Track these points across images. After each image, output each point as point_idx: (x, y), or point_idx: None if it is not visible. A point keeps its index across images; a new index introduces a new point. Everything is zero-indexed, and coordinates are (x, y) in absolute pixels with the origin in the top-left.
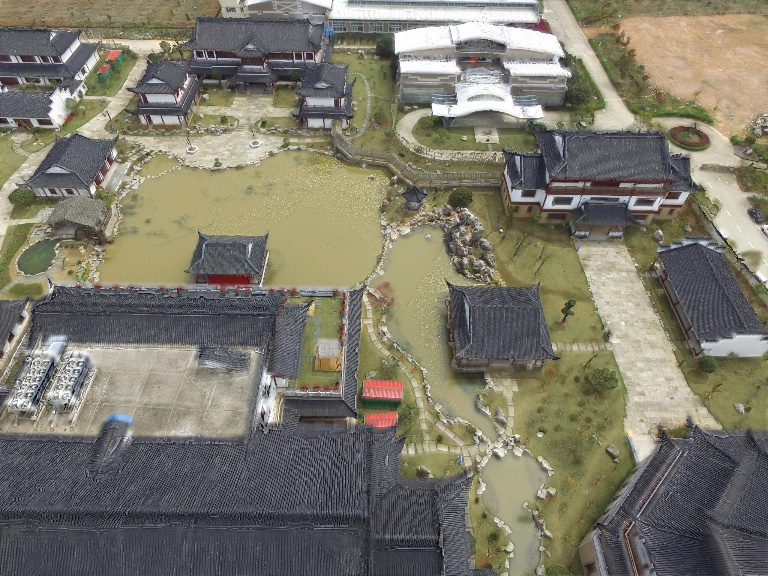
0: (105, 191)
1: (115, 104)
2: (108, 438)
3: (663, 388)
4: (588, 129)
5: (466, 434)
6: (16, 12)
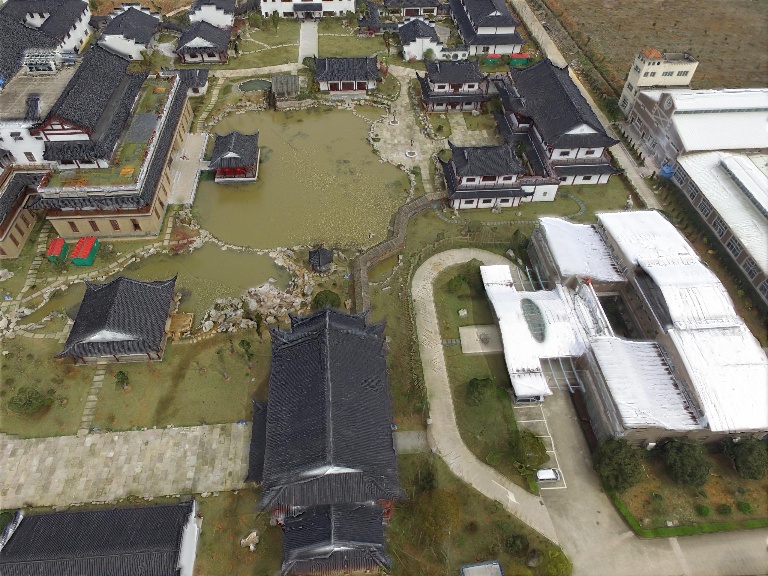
0: None
1: None
2: None
3: (10, 478)
4: None
5: (30, 304)
6: (575, 5)
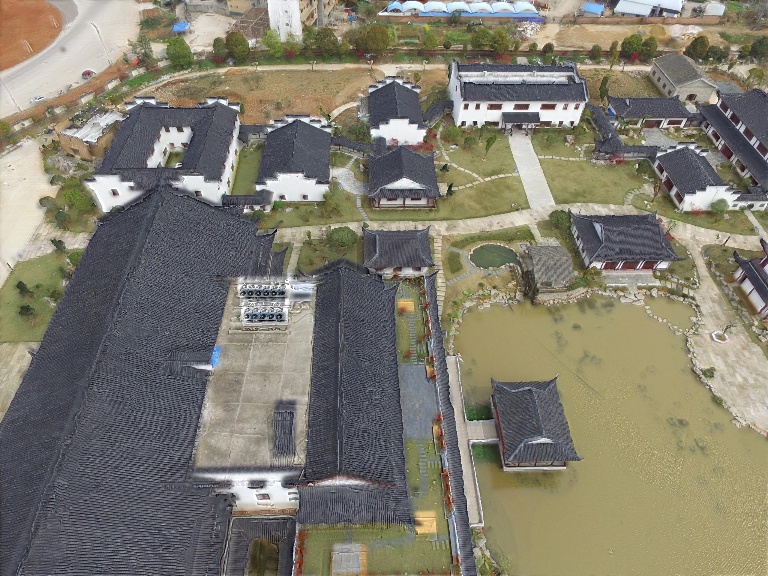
0: (600, 276)
1: (755, 240)
2: (199, 359)
3: None
4: None
5: None
6: None
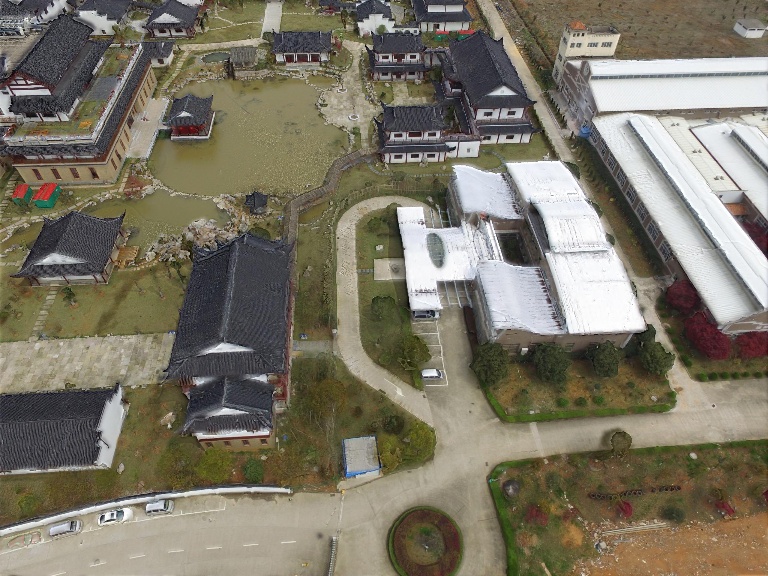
0: None
1: None
2: None
3: None
4: (421, 380)
5: None
6: None
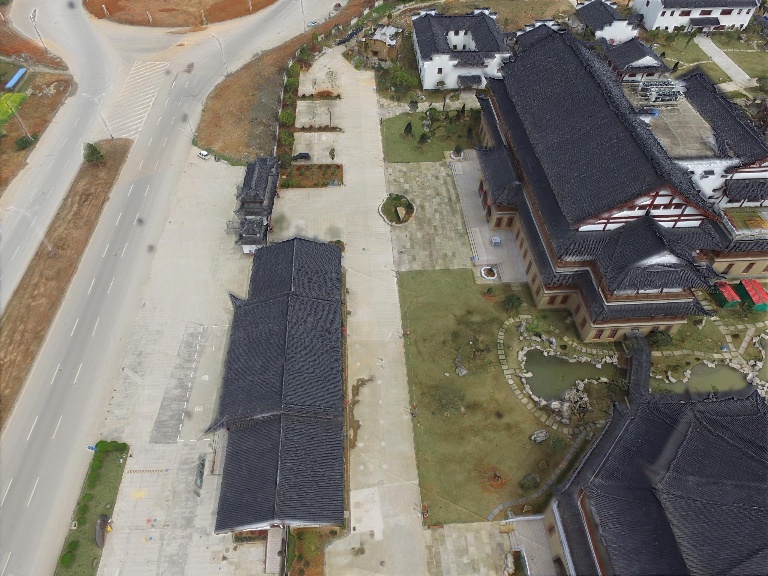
0: None
1: None
2: (649, 113)
3: None
4: None
5: (752, 355)
6: None
